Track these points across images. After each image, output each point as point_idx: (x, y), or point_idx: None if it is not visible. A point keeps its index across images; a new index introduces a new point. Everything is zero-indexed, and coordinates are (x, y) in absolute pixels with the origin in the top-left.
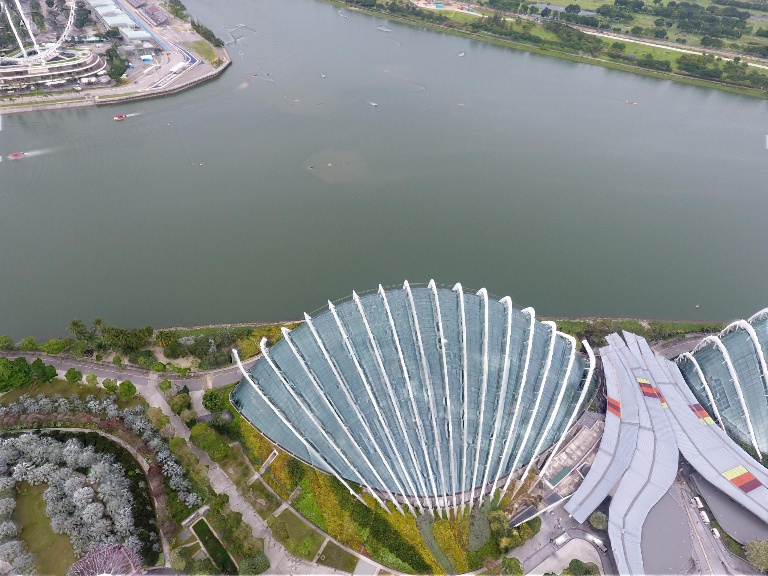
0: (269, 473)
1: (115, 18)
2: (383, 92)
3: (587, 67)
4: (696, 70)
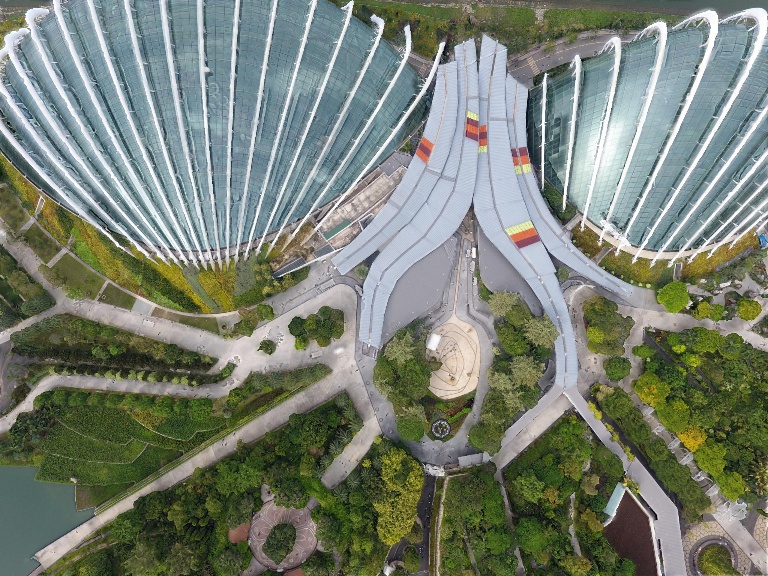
0: (42, 219)
1: None
2: None
3: None
4: None
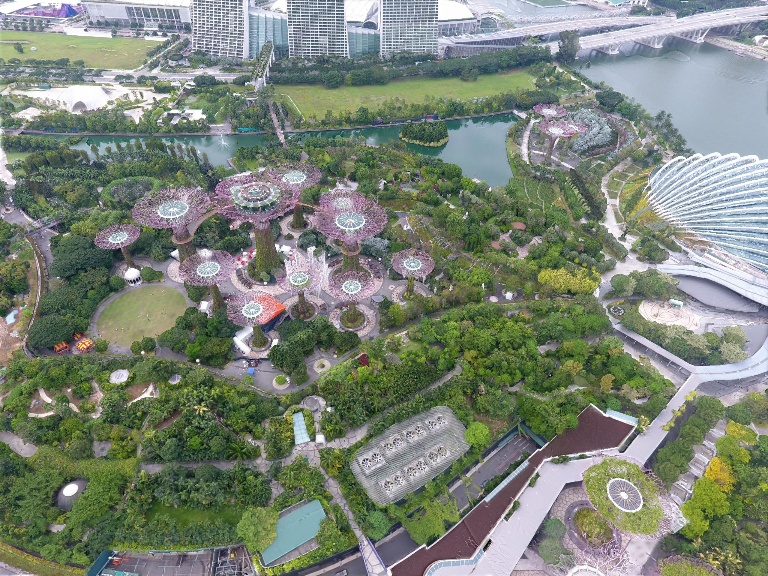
0: None
1: None
2: None
3: None
4: None
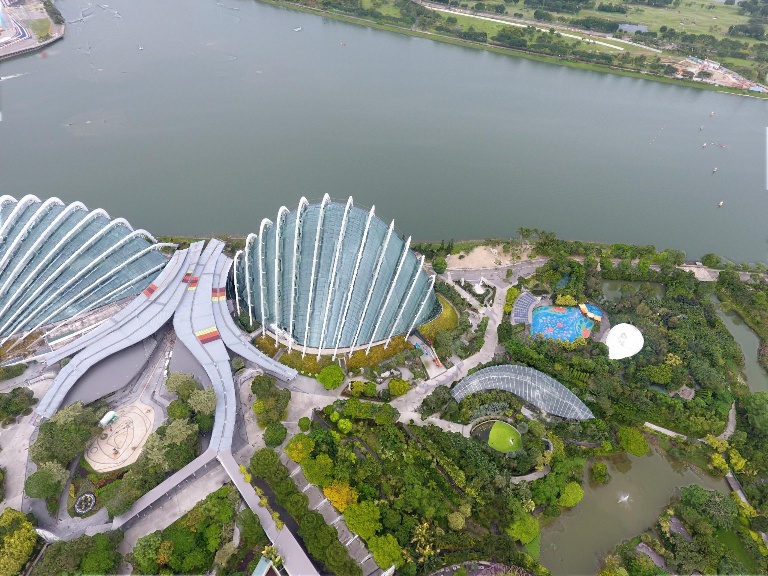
0: None
1: None
2: (192, 62)
3: (420, 40)
4: (505, 40)
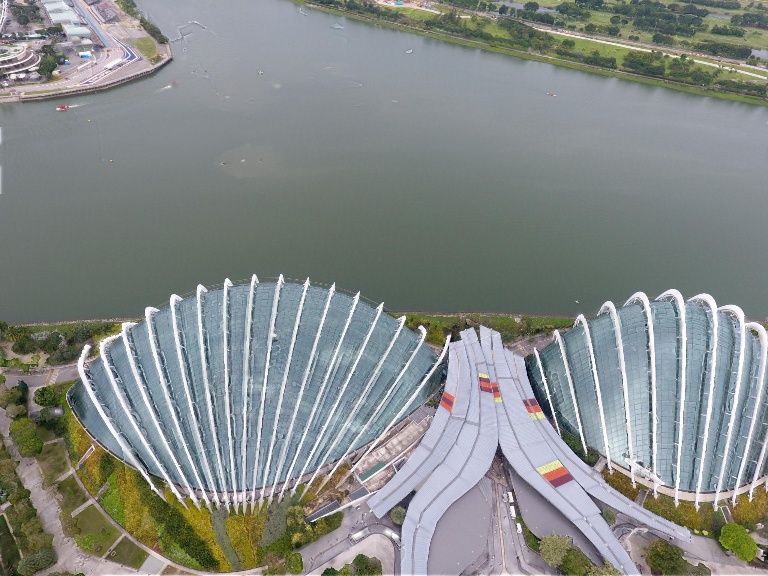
0: (83, 469)
1: (61, 15)
2: (319, 89)
3: (536, 64)
4: (640, 67)
